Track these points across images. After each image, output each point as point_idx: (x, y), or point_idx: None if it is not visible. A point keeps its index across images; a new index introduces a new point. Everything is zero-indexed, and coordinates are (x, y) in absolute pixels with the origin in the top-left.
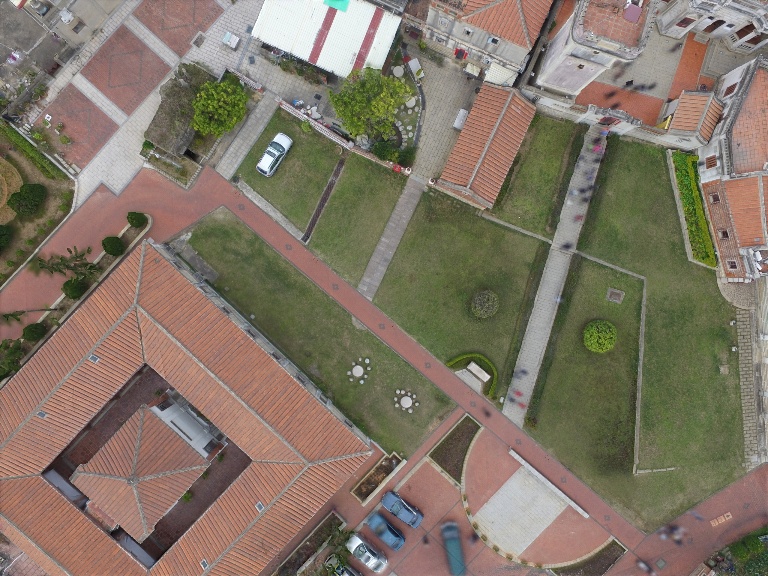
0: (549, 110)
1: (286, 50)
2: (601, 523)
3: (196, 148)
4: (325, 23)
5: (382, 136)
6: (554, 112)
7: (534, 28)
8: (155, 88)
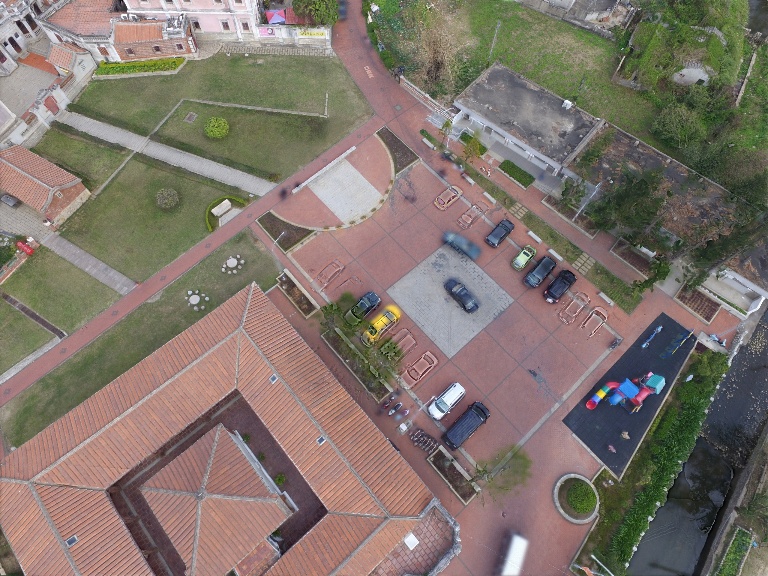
0: (30, 142)
1: None
2: (363, 140)
3: None
4: None
5: None
6: (33, 140)
7: None
8: None
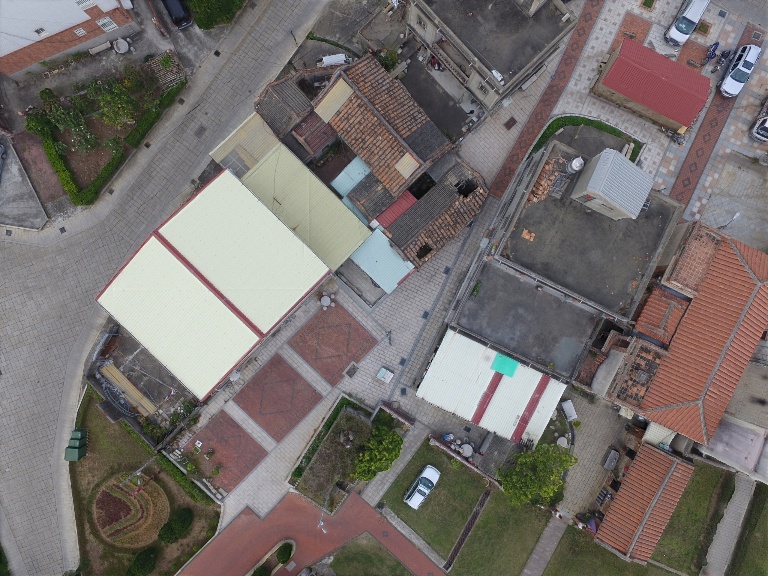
0: None
1: (449, 410)
2: None
3: (344, 478)
4: (490, 386)
5: (540, 493)
6: None
7: (711, 425)
8: (305, 416)
